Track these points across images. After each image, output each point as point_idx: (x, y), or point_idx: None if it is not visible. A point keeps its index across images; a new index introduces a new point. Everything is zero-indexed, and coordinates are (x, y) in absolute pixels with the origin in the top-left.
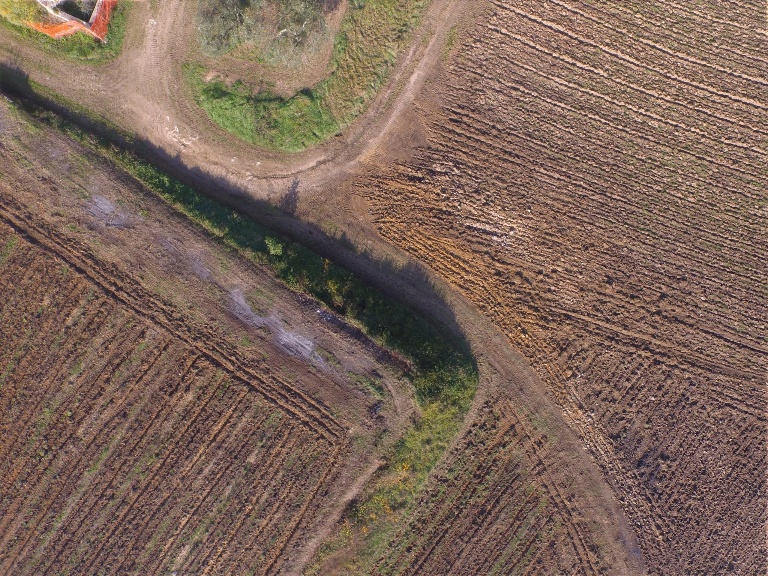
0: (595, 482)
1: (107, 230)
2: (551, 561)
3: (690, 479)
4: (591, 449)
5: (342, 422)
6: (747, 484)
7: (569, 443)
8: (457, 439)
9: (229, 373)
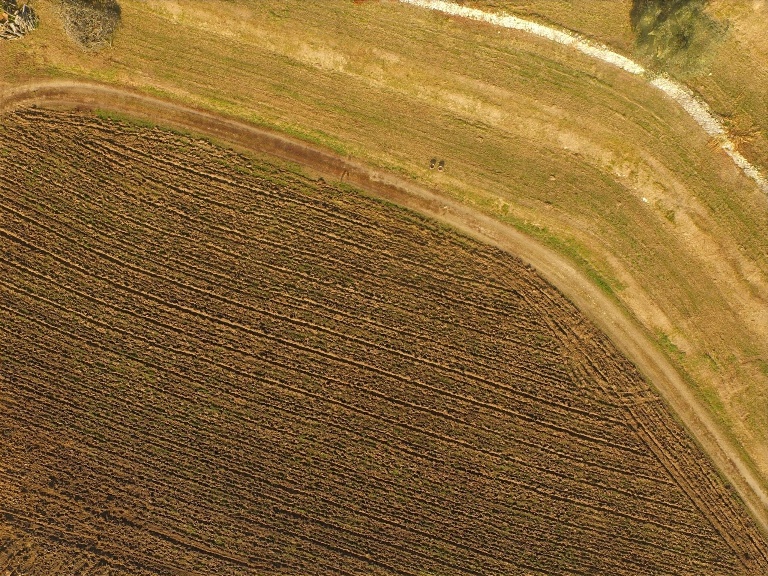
0: None
1: None
2: None
3: None
4: None
5: None
6: None
7: None
8: None
9: None
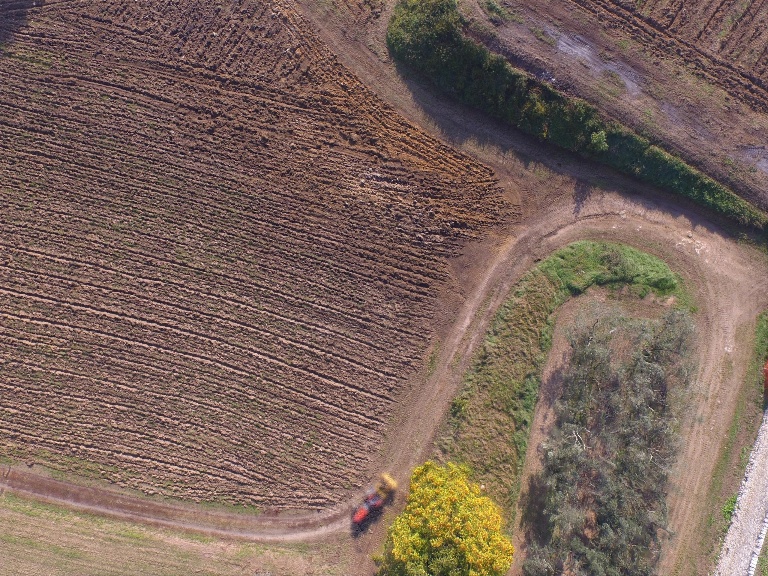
0: None
1: (763, 143)
2: None
3: None
4: None
5: None
6: None
7: None
8: None
9: (637, 14)
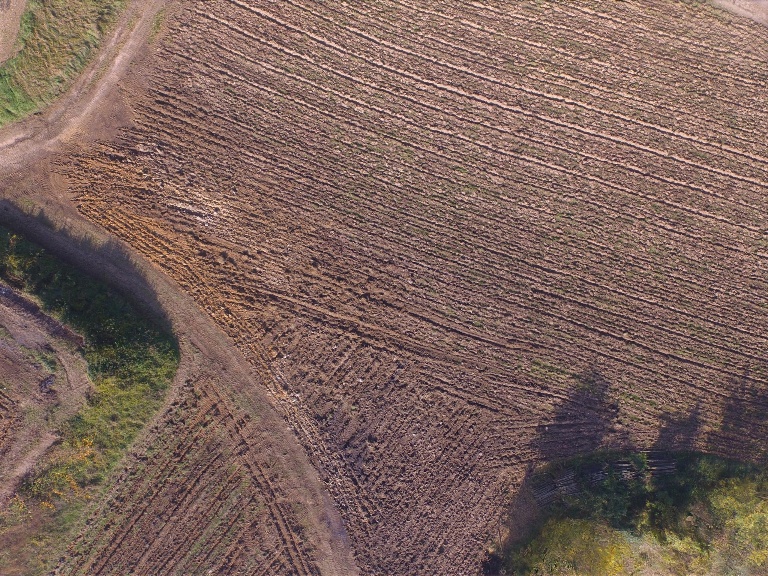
0: (299, 463)
1: None
2: (252, 541)
3: (399, 461)
4: (295, 430)
5: (13, 396)
6: (457, 467)
7: (273, 423)
8: (157, 417)
9: None
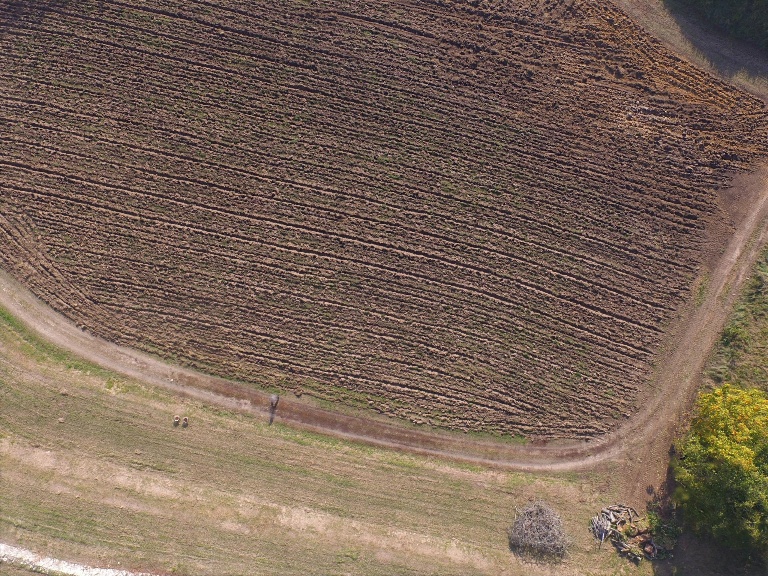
0: None
1: None
2: None
3: None
4: None
5: None
6: None
7: None
8: None
9: None
